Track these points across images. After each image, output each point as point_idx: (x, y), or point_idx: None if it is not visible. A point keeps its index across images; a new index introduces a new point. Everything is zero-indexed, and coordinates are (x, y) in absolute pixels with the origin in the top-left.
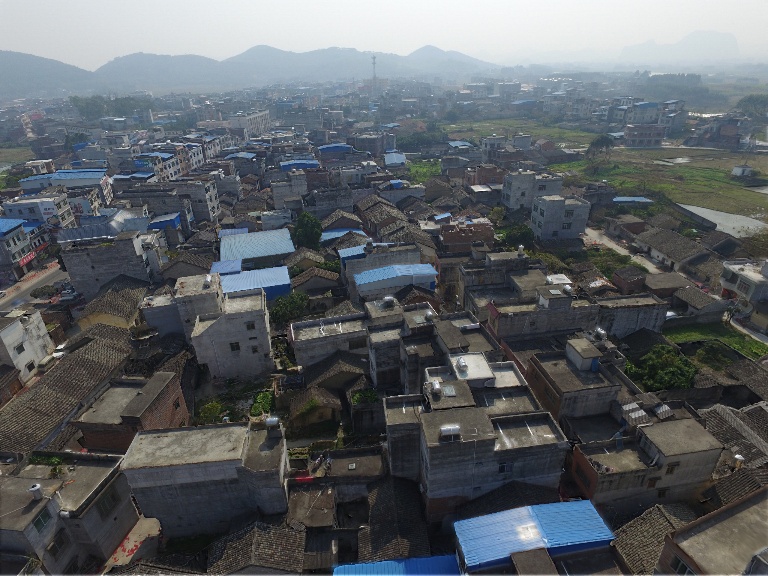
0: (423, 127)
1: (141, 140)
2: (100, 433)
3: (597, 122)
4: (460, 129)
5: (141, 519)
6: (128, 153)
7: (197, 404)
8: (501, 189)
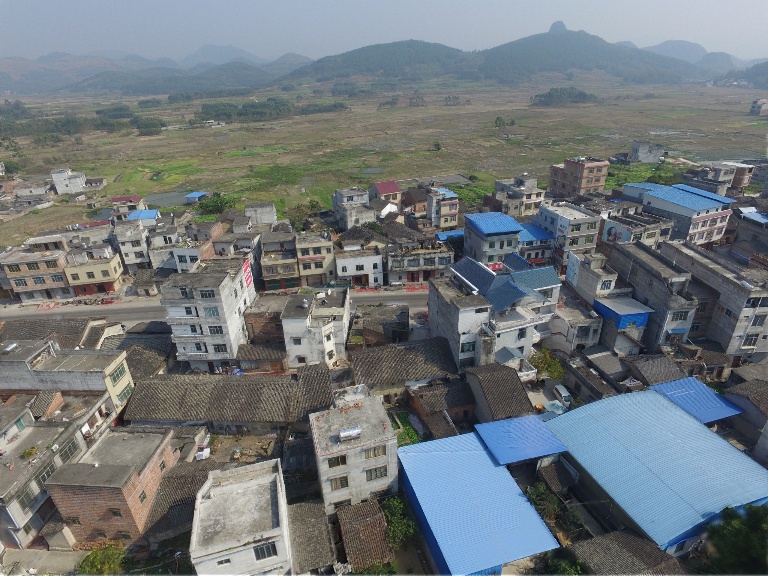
0: None
1: None
2: None
3: None
4: None
5: (20, 551)
6: None
7: (187, 536)
8: None
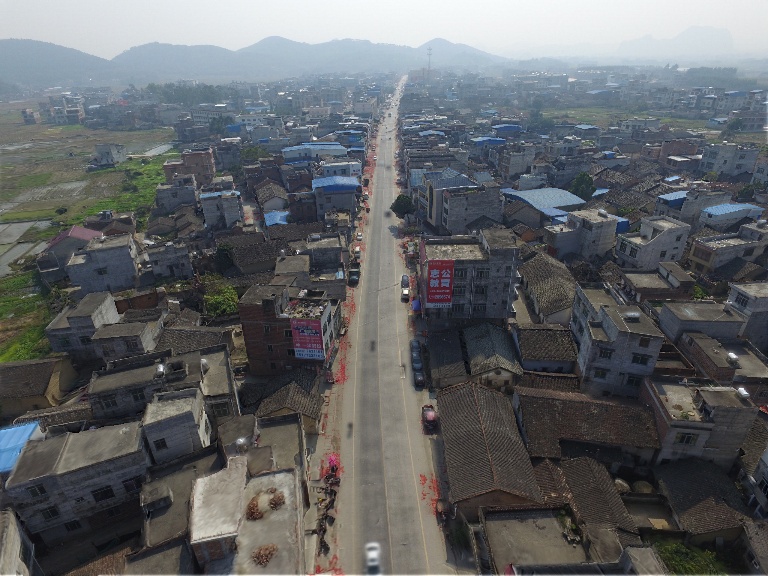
0: (524, 113)
1: (288, 122)
2: (655, 296)
3: (688, 109)
4: (555, 116)
5: None
6: (306, 132)
7: None
8: (699, 159)
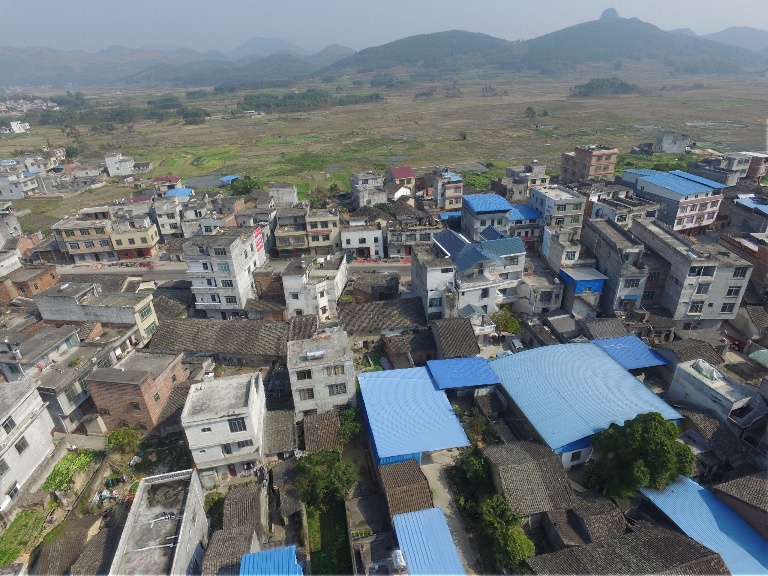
0: None
1: None
2: None
3: None
4: None
5: (66, 435)
6: None
7: None
8: None
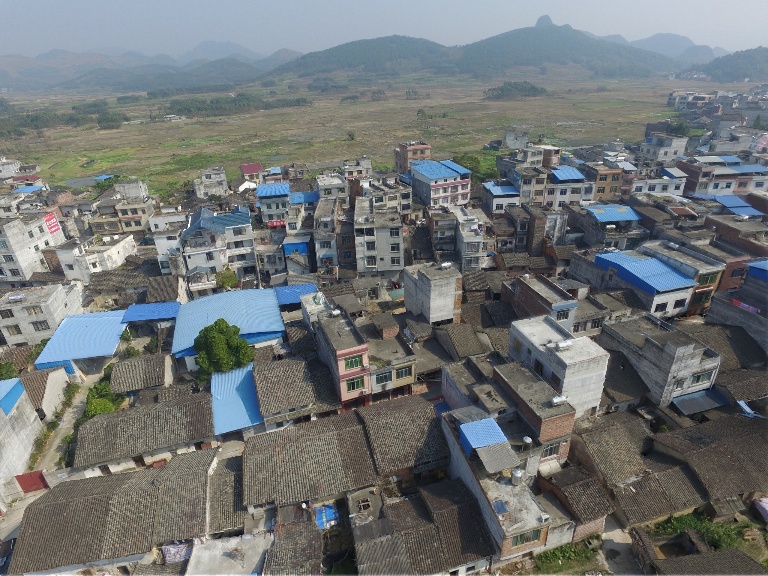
0: None
1: None
2: None
3: None
4: None
5: None
6: None
7: None
8: None
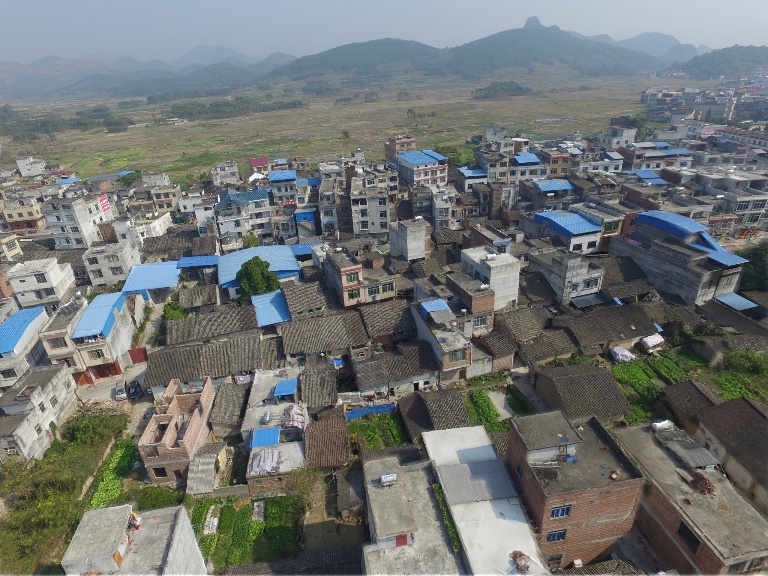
0: None
1: None
2: None
3: None
4: None
5: None
6: None
7: None
8: None
